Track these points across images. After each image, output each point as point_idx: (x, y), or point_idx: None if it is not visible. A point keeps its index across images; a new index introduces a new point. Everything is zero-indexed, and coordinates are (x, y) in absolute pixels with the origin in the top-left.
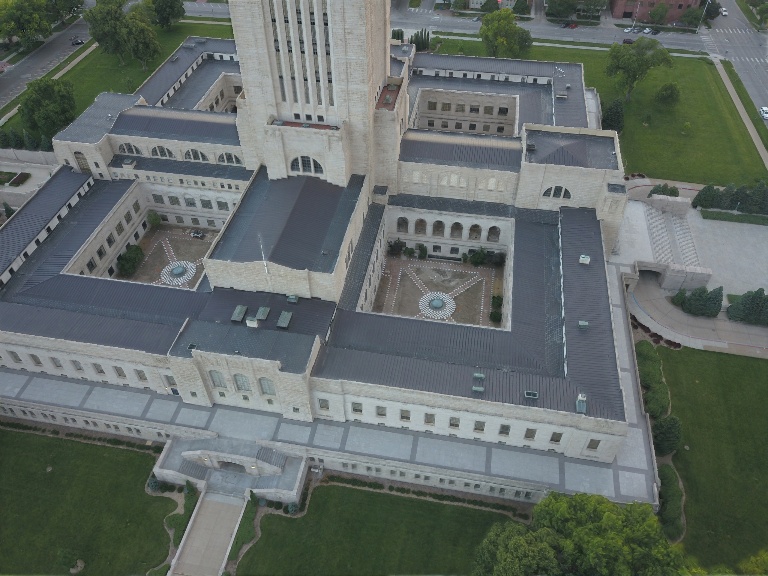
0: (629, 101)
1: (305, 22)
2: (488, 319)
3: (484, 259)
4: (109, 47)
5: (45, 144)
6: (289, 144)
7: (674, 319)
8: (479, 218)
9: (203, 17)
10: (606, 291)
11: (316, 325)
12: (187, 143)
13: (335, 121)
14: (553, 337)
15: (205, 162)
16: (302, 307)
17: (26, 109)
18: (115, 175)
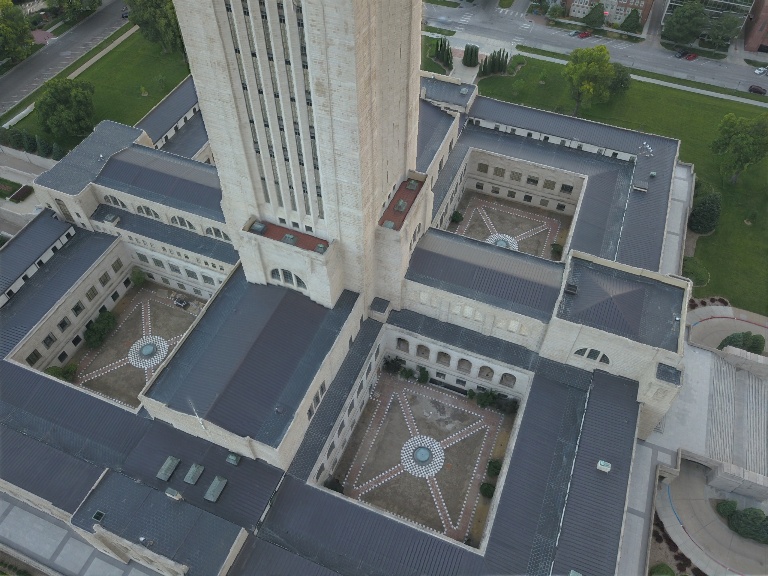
0: (735, 183)
1: (287, 132)
2: (478, 489)
3: (493, 403)
4: (149, 34)
5: (56, 153)
6: (267, 255)
7: (713, 536)
8: (491, 362)
9: None
10: (619, 524)
11: (252, 501)
12: (172, 210)
13: (325, 235)
14: (537, 573)
15: (192, 231)
16: (243, 470)
17: (41, 112)
18: (98, 227)
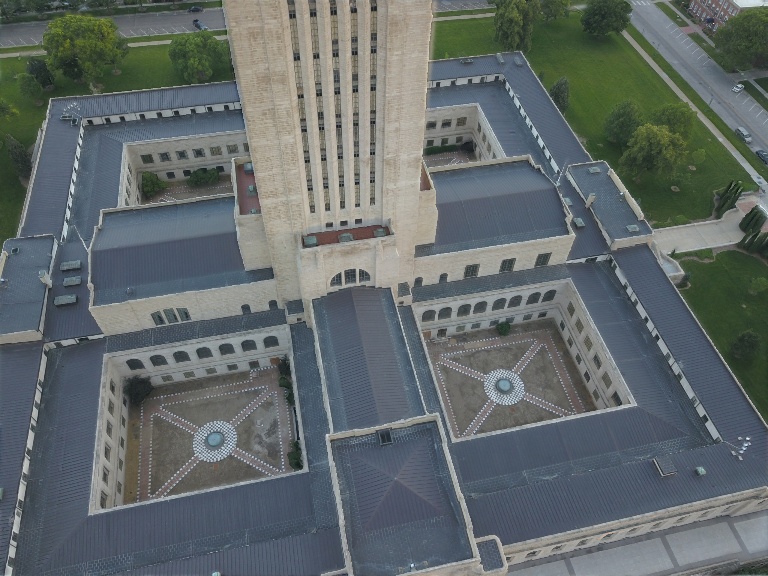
0: None
1: None
2: None
3: None
4: None
5: None
6: None
7: None
8: (299, 429)
9: (652, 46)
10: None
11: (69, 327)
12: None
13: None
14: (94, 571)
15: None
16: None
17: None
18: None
